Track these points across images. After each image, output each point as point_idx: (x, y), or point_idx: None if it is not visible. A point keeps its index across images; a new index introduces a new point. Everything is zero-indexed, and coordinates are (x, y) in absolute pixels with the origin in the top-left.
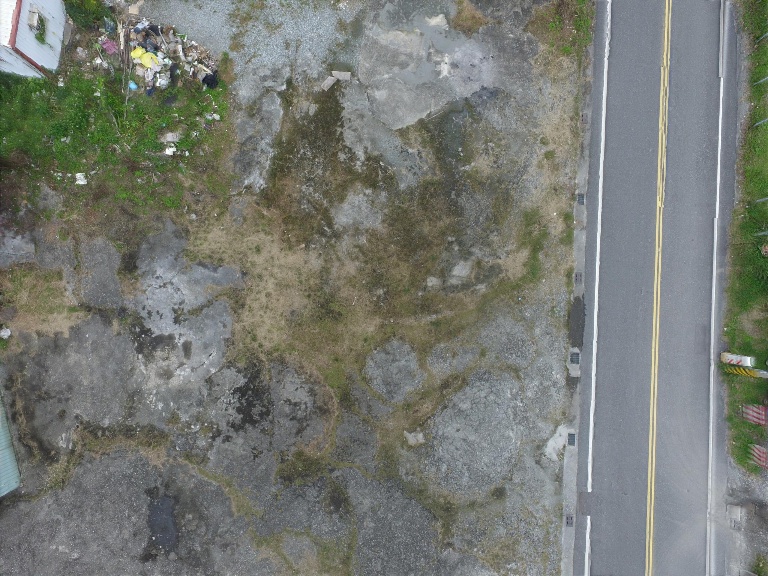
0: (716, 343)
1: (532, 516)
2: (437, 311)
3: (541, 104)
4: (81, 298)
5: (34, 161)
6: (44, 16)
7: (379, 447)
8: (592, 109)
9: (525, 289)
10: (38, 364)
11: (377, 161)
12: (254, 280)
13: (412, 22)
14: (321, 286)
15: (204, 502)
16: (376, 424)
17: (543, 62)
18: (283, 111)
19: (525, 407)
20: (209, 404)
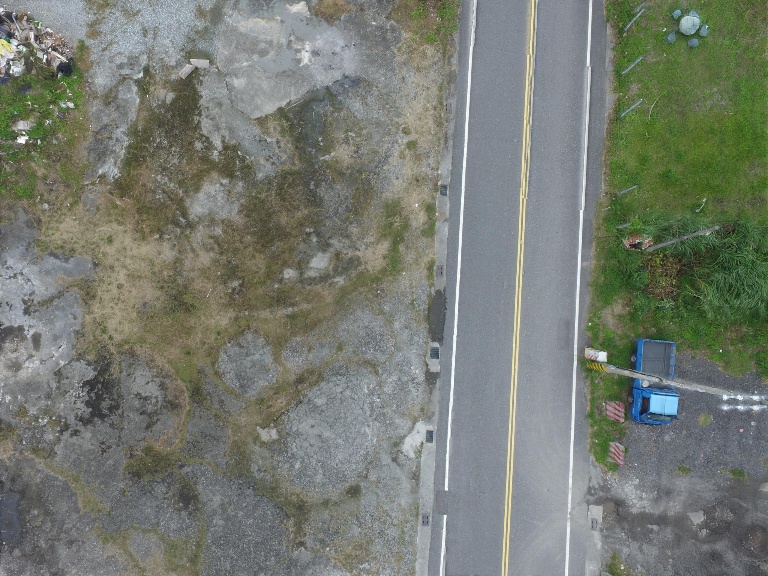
0: (580, 338)
1: (387, 515)
2: (293, 304)
3: (404, 93)
4: None
5: None
6: None
7: (231, 443)
8: (456, 98)
9: (384, 282)
10: None
11: (235, 150)
12: (106, 271)
13: (272, 9)
14: (175, 278)
15: (50, 498)
16: (228, 419)
17: (406, 50)
18: (139, 99)
19: (382, 403)
20: (57, 397)
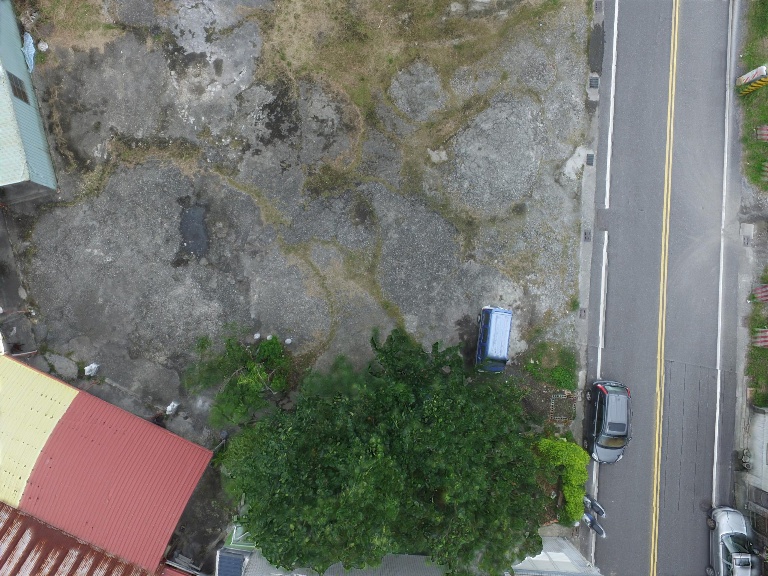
0: (732, 69)
1: (551, 230)
2: (460, 35)
3: None
4: (116, 16)
5: None
6: None
7: (403, 163)
8: None
9: (546, 16)
10: (74, 78)
11: None
12: (283, 2)
13: None
14: (348, 10)
15: (234, 211)
16: (400, 141)
17: None
18: None
19: (545, 128)
20: (239, 119)
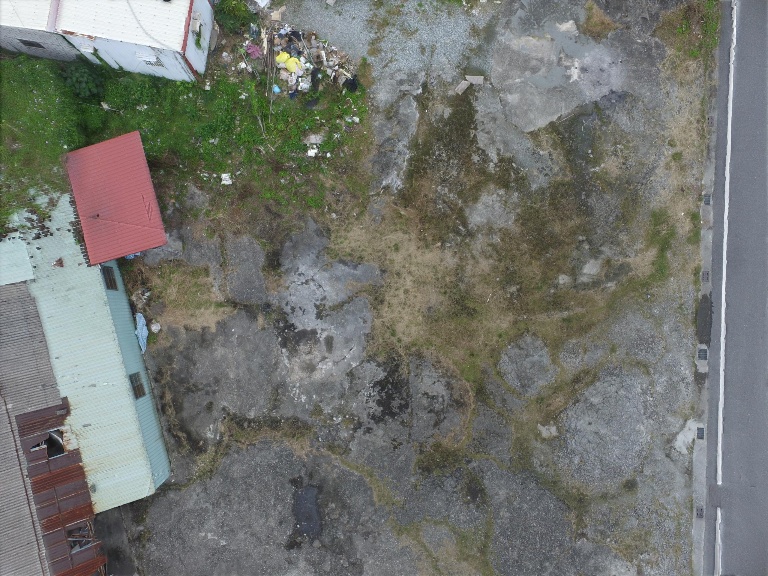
0: None
1: (663, 507)
2: (569, 308)
3: (668, 107)
4: (227, 294)
5: (182, 162)
6: (200, 23)
7: (514, 439)
8: (718, 112)
9: (654, 287)
10: (186, 357)
11: (510, 162)
12: (392, 277)
13: (543, 28)
14: (457, 283)
15: (346, 491)
16: (511, 417)
17: (670, 67)
18: (419, 114)
19: (655, 401)
20: (350, 397)
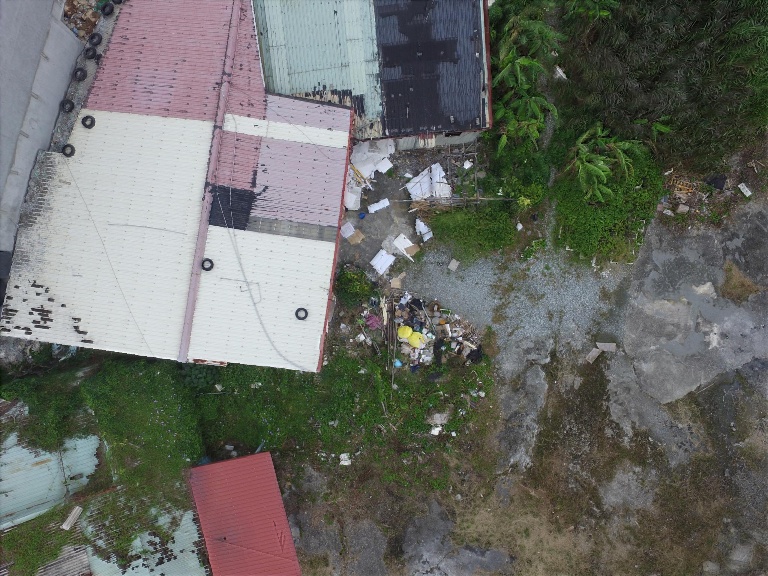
0: None
1: None
2: None
3: None
4: None
5: (300, 443)
6: None
7: None
8: None
9: None
10: None
11: (646, 437)
12: (524, 565)
13: (679, 291)
14: (592, 571)
15: None
16: None
17: None
18: (548, 385)
19: None
20: None
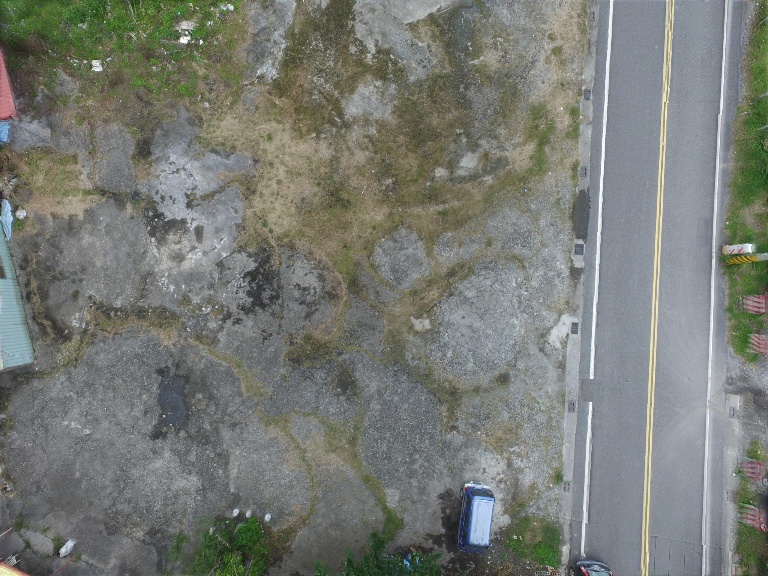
0: (718, 236)
1: (535, 401)
2: (445, 201)
3: (549, 1)
4: (96, 182)
5: (51, 46)
6: None
7: (386, 332)
8: (599, 7)
9: (531, 181)
10: (53, 245)
11: (388, 54)
12: (265, 167)
13: None
14: (331, 175)
15: (214, 382)
16: (383, 310)
17: None
18: (296, 3)
19: (530, 296)
20: (220, 287)
